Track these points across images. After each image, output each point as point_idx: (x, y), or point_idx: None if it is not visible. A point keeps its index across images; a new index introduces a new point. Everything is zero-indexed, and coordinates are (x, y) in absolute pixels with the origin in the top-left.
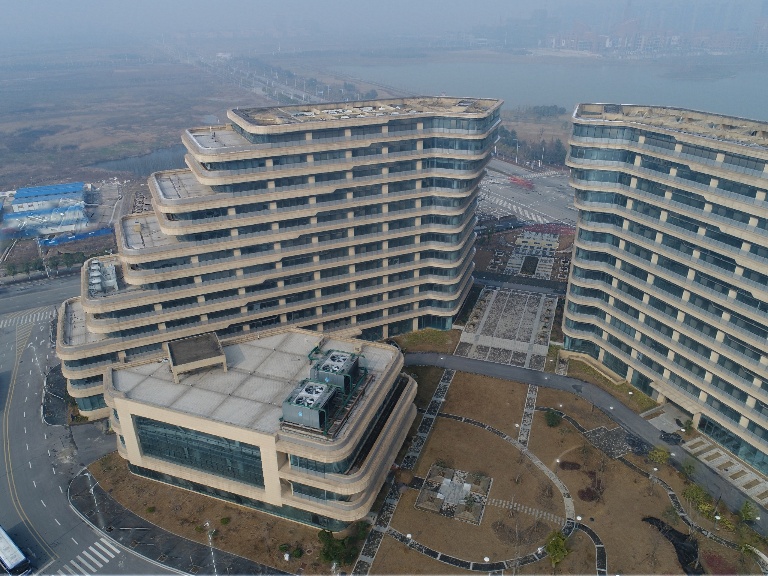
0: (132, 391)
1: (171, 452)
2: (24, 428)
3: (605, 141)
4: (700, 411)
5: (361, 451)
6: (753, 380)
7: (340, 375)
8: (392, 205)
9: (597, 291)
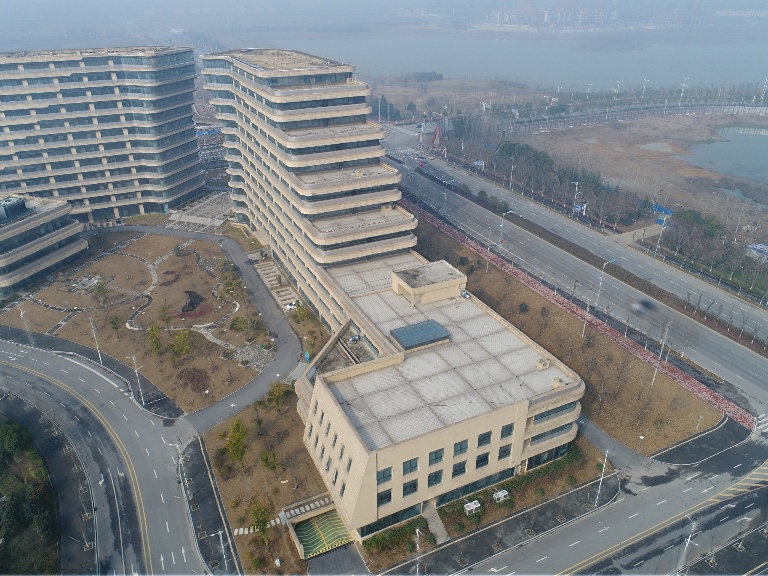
0: None
1: None
2: None
3: (218, 70)
4: (268, 244)
5: None
6: None
7: (1, 206)
8: (101, 119)
9: (240, 177)
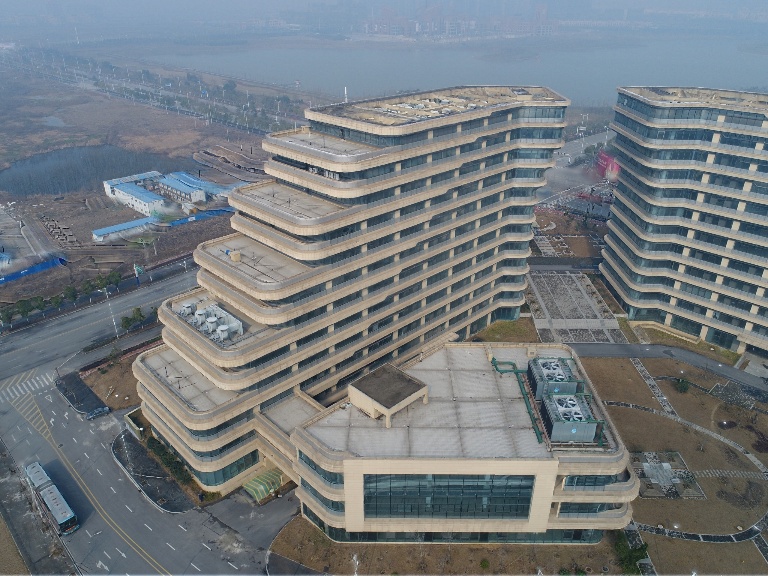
0: (350, 448)
1: (407, 506)
2: (145, 525)
3: (684, 122)
4: None
5: None
6: None
7: (573, 382)
8: (483, 200)
9: (666, 261)
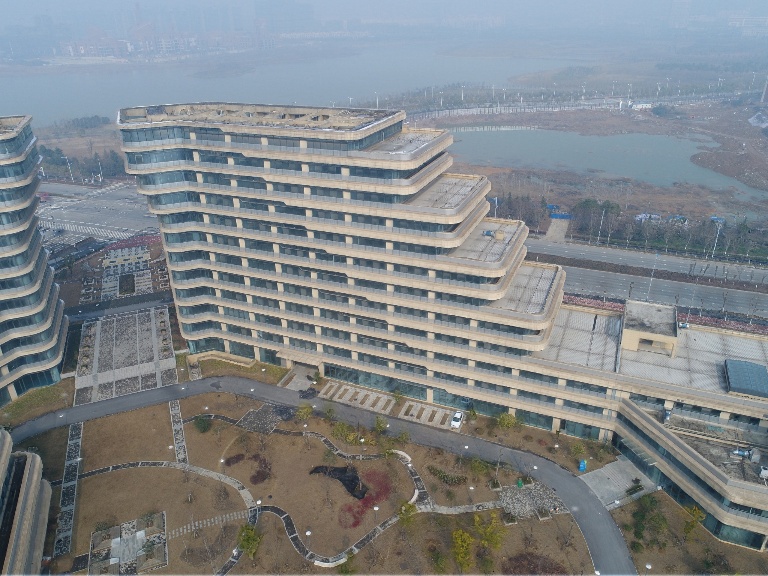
0: None
1: None
2: None
3: (159, 143)
4: (322, 361)
5: None
6: (349, 320)
7: None
8: None
9: (202, 288)
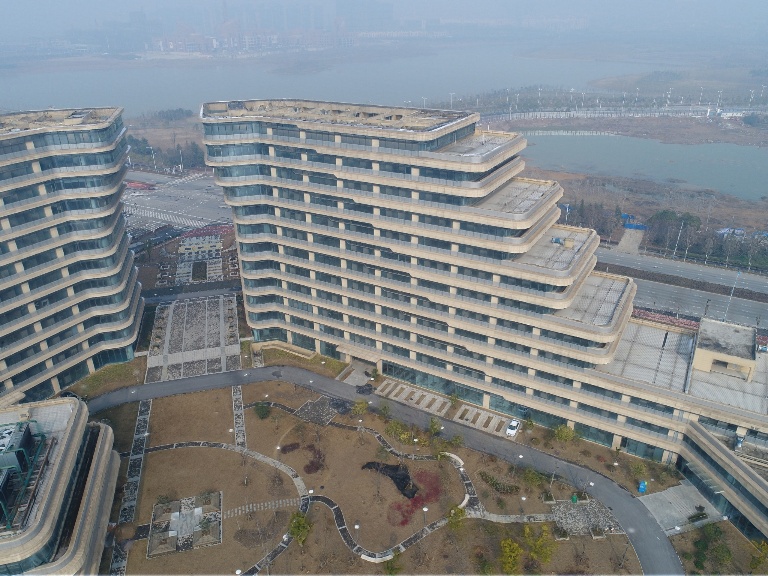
0: None
1: None
2: None
3: (237, 137)
4: (380, 358)
5: (64, 527)
6: (410, 319)
7: (9, 453)
8: (20, 240)
9: (269, 279)
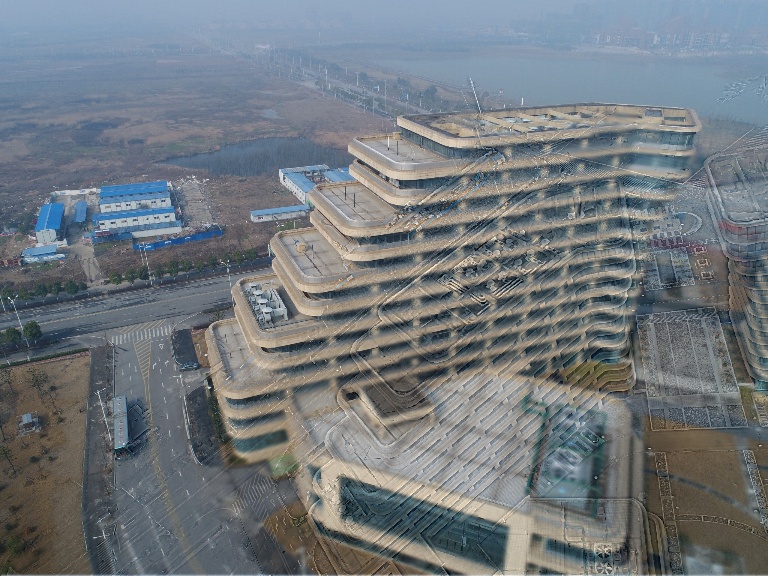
0: None
1: None
2: None
3: None
4: None
5: None
6: None
7: None
8: (559, 337)
9: None
